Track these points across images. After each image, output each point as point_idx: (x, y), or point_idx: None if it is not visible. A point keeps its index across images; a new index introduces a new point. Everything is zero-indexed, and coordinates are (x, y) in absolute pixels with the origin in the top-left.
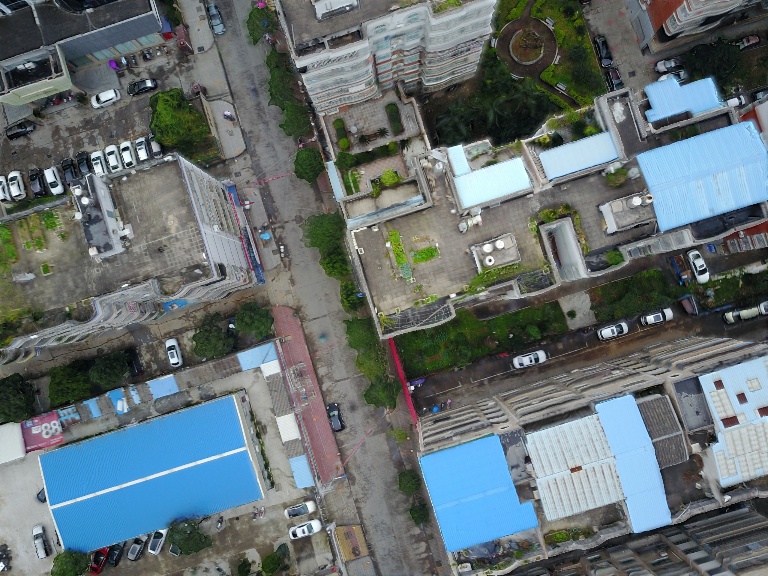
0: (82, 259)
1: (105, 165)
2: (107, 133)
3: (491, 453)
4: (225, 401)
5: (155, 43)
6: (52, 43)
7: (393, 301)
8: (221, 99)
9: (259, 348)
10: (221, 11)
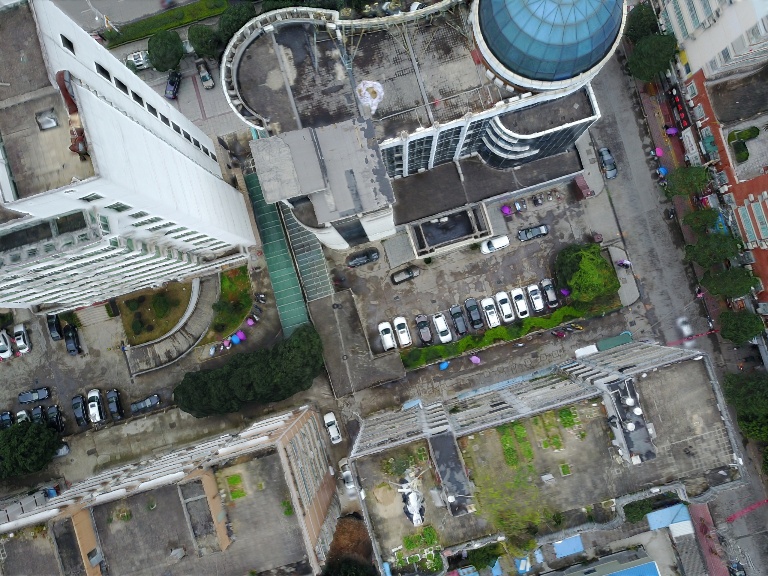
0: (601, 459)
1: (496, 313)
2: (494, 279)
3: None
4: (646, 567)
5: (548, 188)
6: (477, 200)
7: None
8: (613, 245)
9: (670, 508)
10: (612, 154)
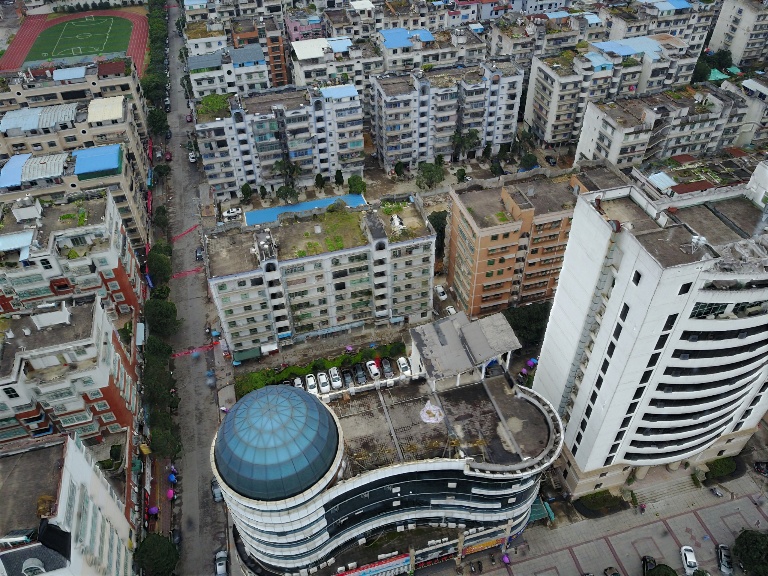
0: (285, 240)
1: None
2: None
3: (81, 168)
4: None
5: None
6: None
7: (96, 202)
8: None
9: None
10: None
